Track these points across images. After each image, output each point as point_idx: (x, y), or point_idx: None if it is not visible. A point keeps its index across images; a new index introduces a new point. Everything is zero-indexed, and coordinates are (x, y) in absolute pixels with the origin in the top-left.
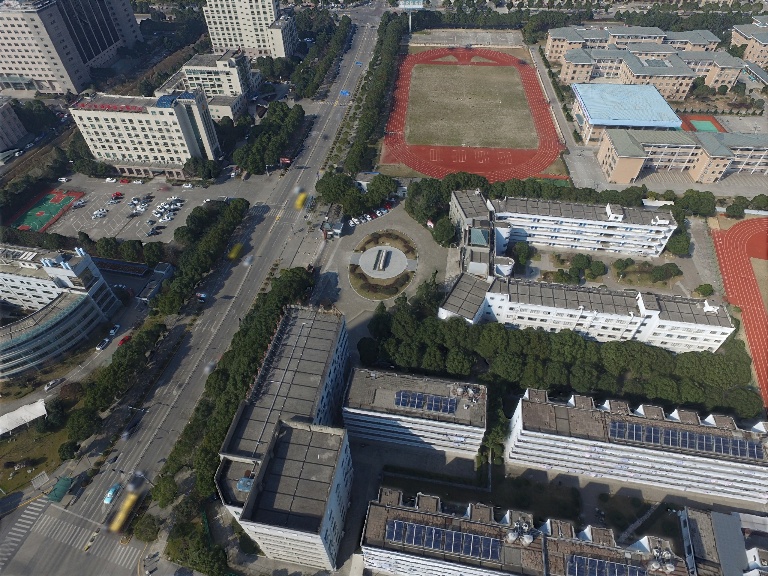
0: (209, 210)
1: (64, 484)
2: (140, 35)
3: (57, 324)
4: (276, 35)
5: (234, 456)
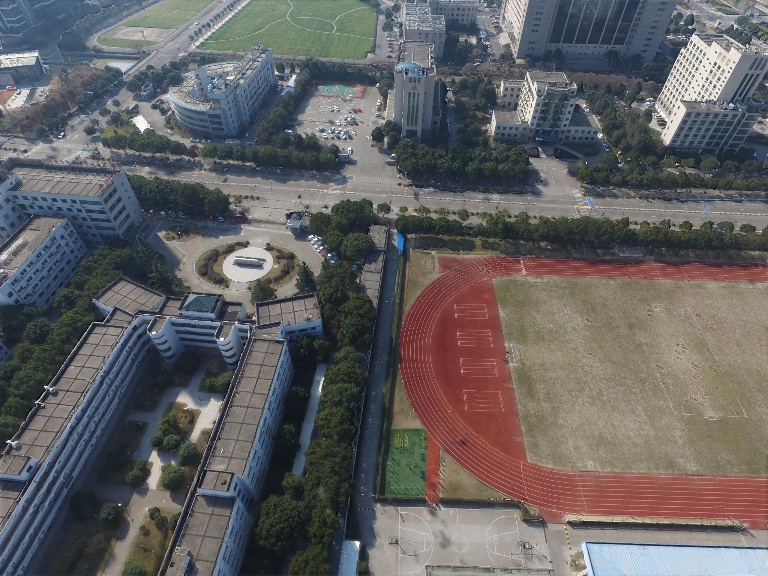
0: (314, 144)
1: (90, 148)
2: (653, 52)
3: (190, 110)
4: (680, 113)
5: (4, 162)
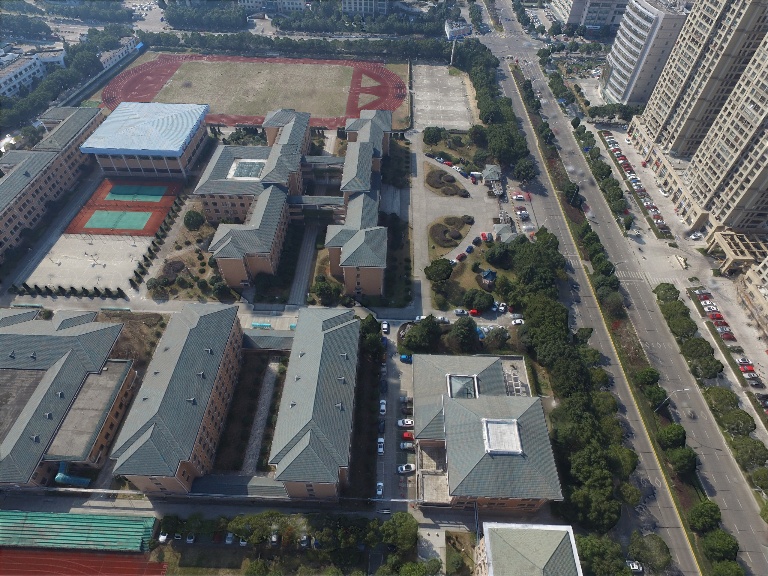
0: (116, 6)
1: None
2: None
3: None
4: None
5: None
